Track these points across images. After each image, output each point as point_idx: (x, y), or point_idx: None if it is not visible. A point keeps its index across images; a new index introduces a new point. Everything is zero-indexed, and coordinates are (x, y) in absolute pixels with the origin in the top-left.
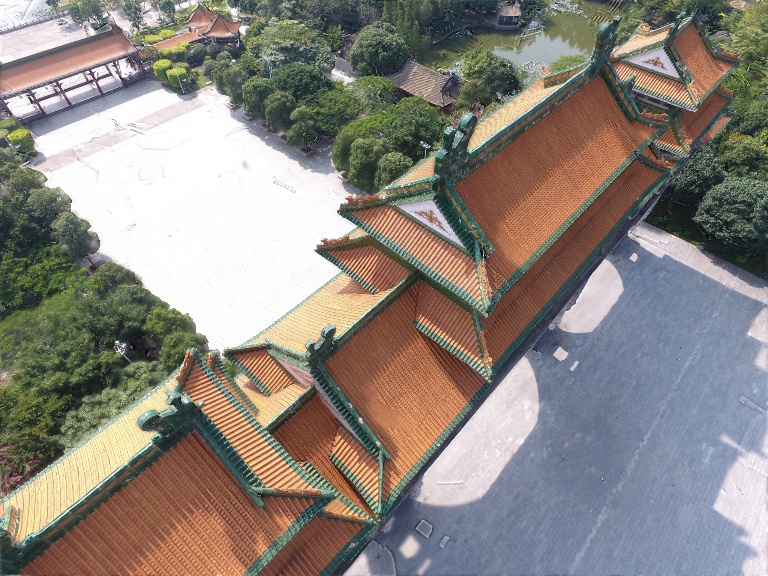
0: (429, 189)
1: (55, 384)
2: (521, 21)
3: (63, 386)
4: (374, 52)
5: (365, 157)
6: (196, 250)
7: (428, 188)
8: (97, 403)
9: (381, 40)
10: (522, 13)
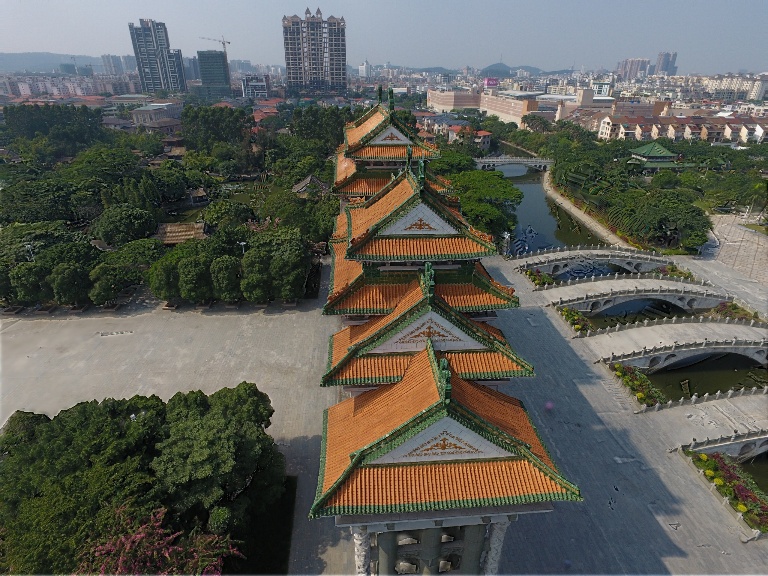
0: (386, 125)
1: (116, 451)
2: (209, 198)
3: (125, 451)
4: (128, 223)
5: (198, 268)
6: (68, 407)
7: (385, 125)
8: (171, 445)
9: (130, 213)
10: (206, 194)
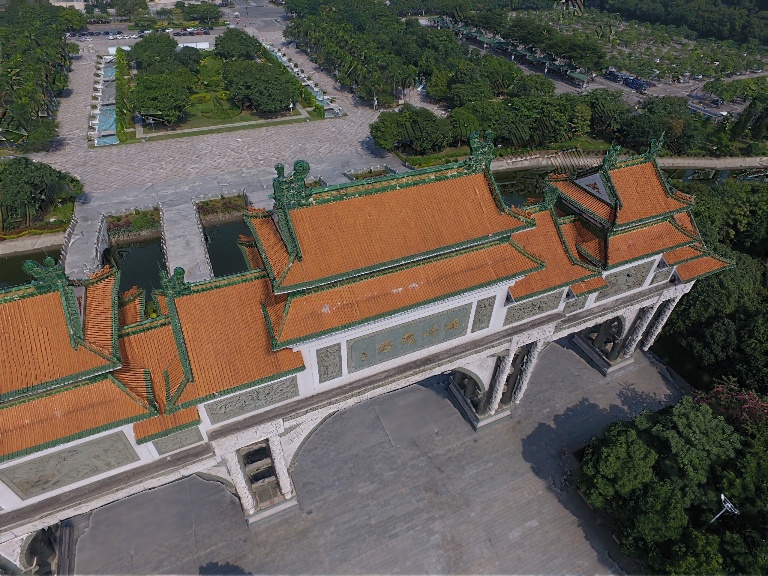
0: None
1: None
2: None
3: None
4: None
5: None
6: None
7: None
8: None
9: None
10: None
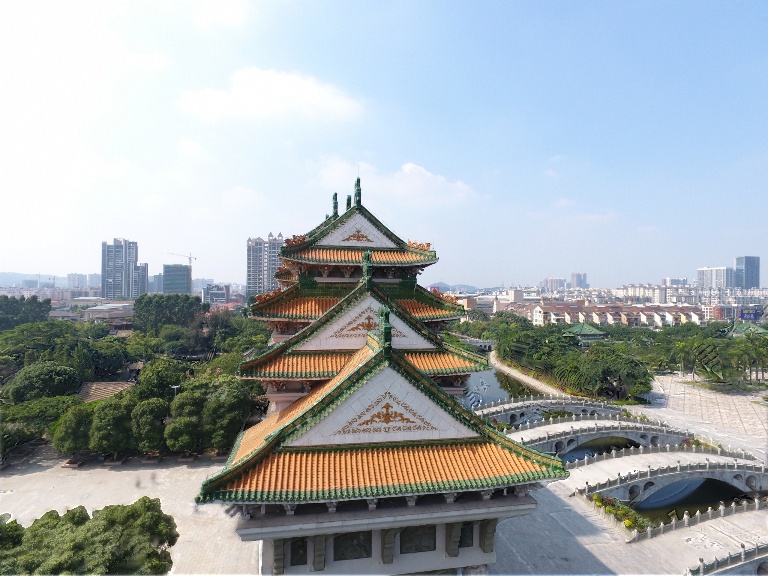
0: None
1: None
2: None
3: None
4: (48, 378)
5: (117, 411)
6: None
7: None
8: (19, 555)
9: (53, 369)
10: None
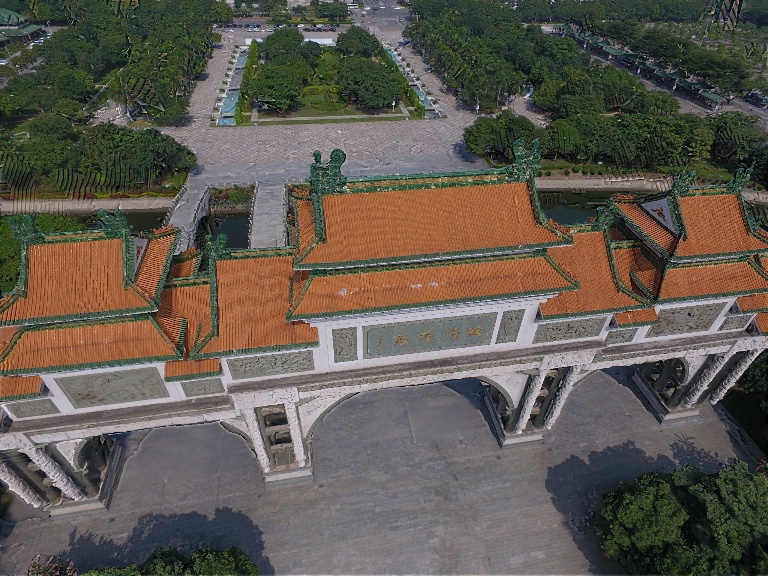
0: None
1: None
2: None
3: None
4: None
5: None
6: None
7: None
8: None
9: None
10: None
